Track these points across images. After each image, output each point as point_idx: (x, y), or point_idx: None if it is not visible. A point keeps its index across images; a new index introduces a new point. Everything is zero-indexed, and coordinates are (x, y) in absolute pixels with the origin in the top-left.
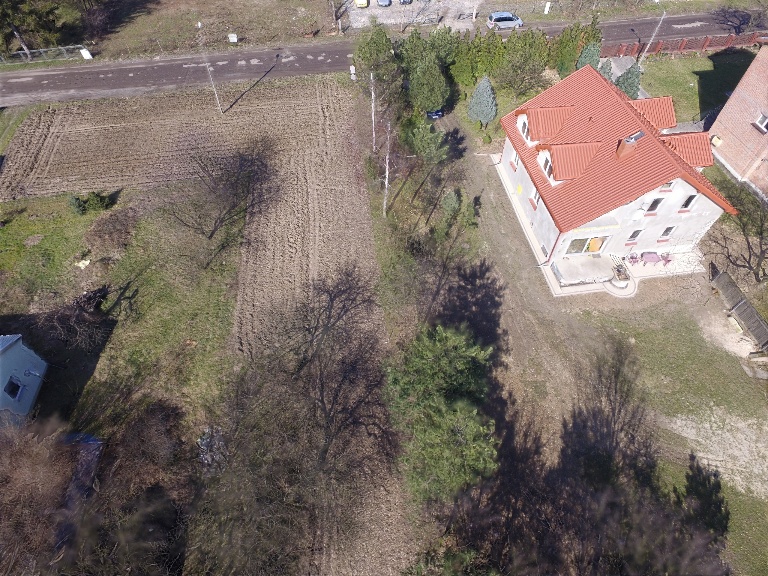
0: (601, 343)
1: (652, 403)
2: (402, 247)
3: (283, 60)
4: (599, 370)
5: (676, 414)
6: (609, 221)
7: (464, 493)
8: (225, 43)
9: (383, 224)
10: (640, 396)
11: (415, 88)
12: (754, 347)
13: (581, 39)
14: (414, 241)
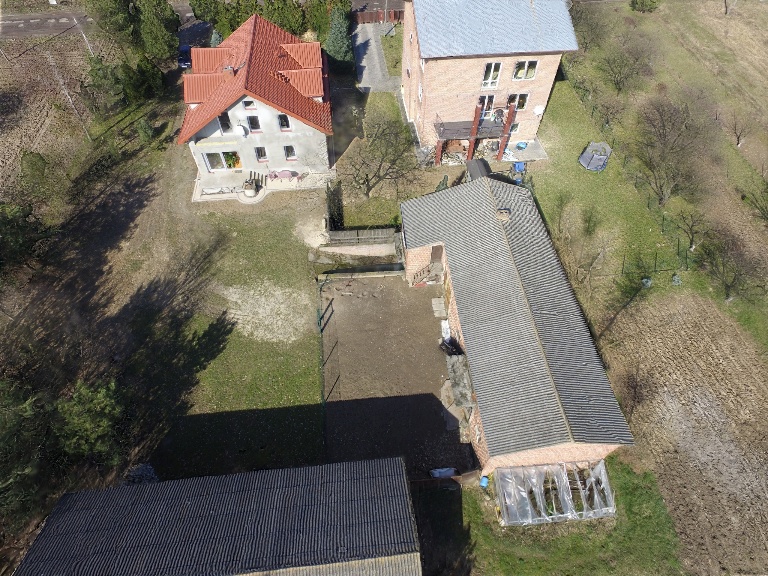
0: (209, 235)
1: (219, 277)
2: (91, 163)
3: (88, 19)
4: (194, 254)
5: (233, 285)
6: (230, 138)
7: (29, 330)
8: (47, 5)
9: (88, 147)
10: (213, 272)
11: (143, 36)
12: (327, 240)
13: (329, 4)
14: (104, 159)
